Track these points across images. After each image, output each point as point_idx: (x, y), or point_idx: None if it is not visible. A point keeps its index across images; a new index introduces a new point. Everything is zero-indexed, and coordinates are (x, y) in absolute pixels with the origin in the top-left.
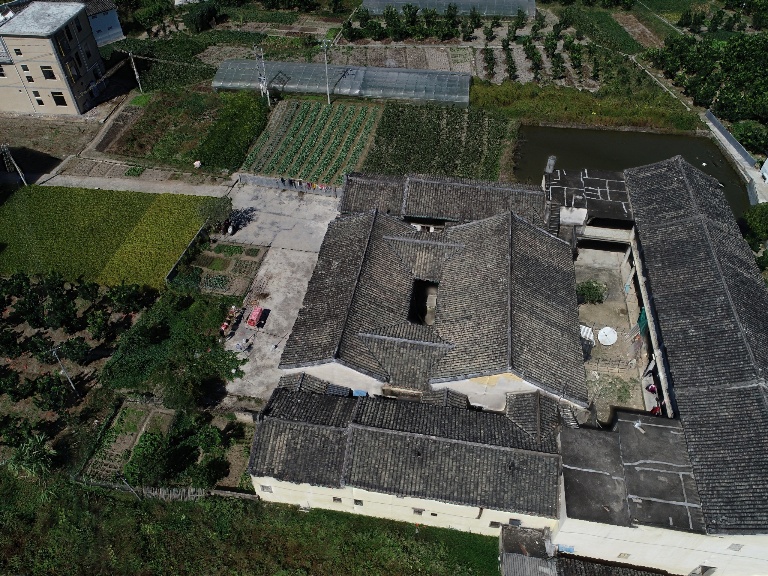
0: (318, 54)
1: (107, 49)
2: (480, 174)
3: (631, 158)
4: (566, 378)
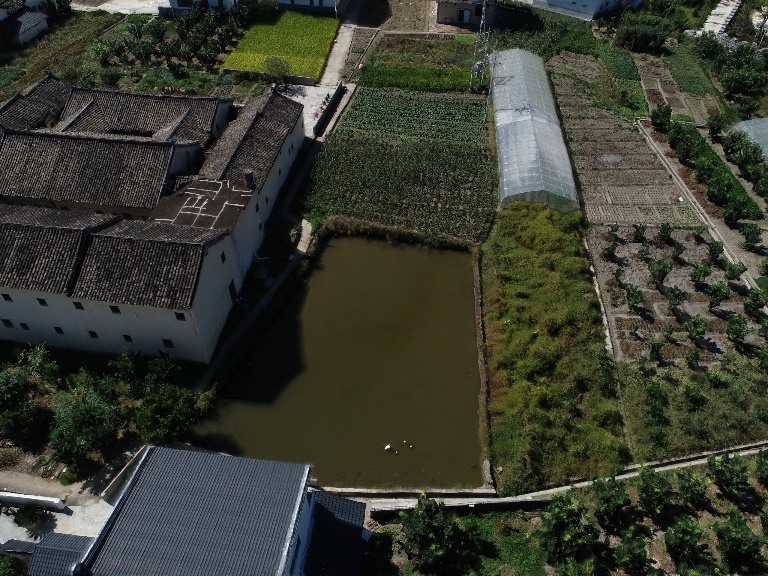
0: (606, 110)
1: (560, 17)
2: (355, 211)
3: (401, 355)
4: (5, 177)
